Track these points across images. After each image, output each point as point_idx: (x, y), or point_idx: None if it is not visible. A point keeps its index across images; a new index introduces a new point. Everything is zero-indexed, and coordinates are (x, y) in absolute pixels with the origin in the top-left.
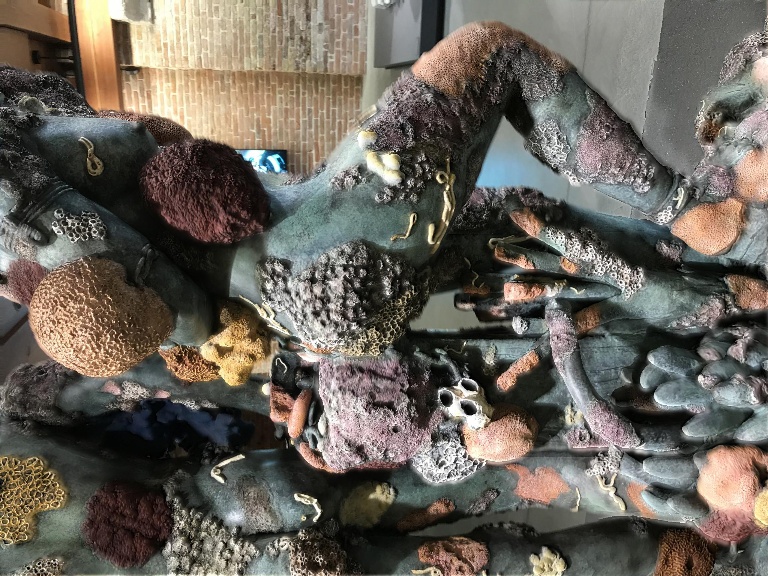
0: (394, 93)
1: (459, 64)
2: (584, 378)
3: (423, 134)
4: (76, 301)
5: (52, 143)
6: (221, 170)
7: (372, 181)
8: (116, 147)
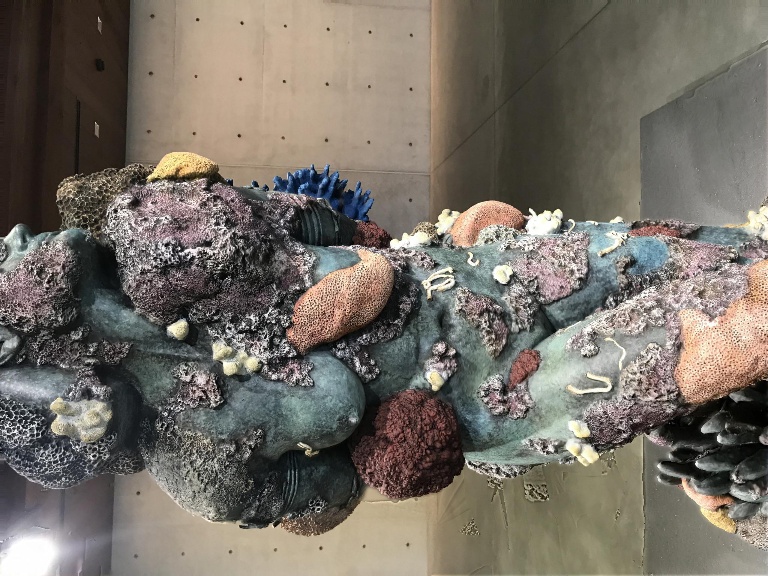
0: (640, 380)
1: (736, 379)
2: (661, 428)
3: (638, 432)
4: (307, 534)
5: (274, 454)
6: (429, 483)
7: (563, 453)
8: (332, 444)
